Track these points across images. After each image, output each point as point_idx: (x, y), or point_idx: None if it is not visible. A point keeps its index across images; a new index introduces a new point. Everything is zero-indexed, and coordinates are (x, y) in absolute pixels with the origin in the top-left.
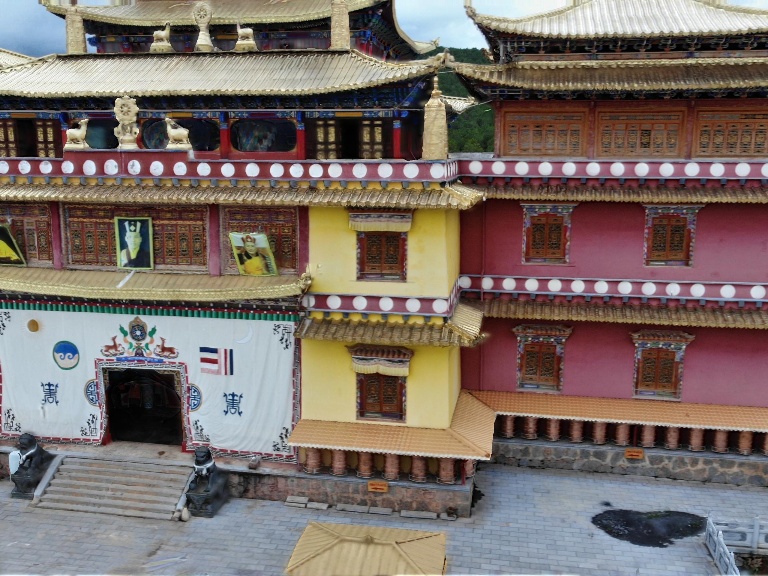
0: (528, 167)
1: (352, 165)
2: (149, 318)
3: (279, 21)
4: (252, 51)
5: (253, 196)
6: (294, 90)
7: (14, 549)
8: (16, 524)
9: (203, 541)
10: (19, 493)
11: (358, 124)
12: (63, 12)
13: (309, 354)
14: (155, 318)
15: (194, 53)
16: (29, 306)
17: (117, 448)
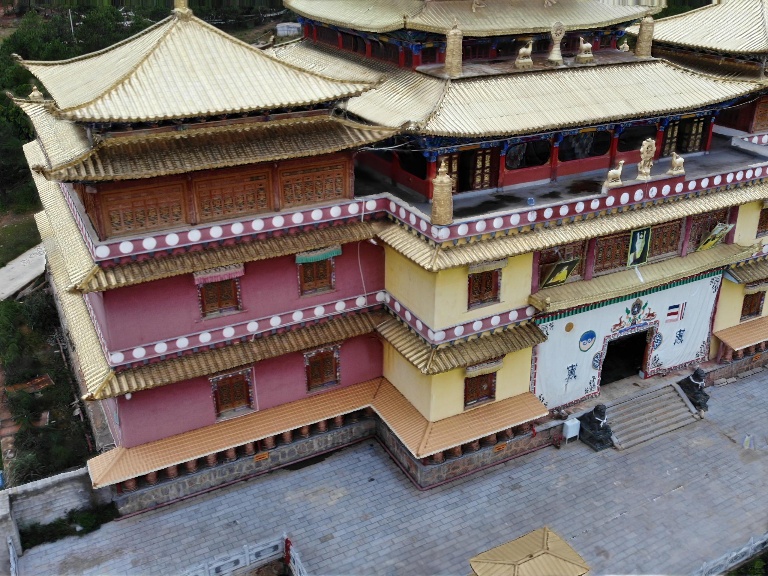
0: (767, 137)
1: (767, 167)
2: (645, 297)
3: (581, 28)
4: (599, 64)
5: (732, 200)
6: (683, 107)
7: (677, 474)
8: (641, 463)
9: (736, 423)
10: (603, 446)
11: (690, 121)
12: (418, 27)
13: (725, 291)
14: (649, 296)
15: (559, 69)
16: (569, 313)
17: (608, 393)
